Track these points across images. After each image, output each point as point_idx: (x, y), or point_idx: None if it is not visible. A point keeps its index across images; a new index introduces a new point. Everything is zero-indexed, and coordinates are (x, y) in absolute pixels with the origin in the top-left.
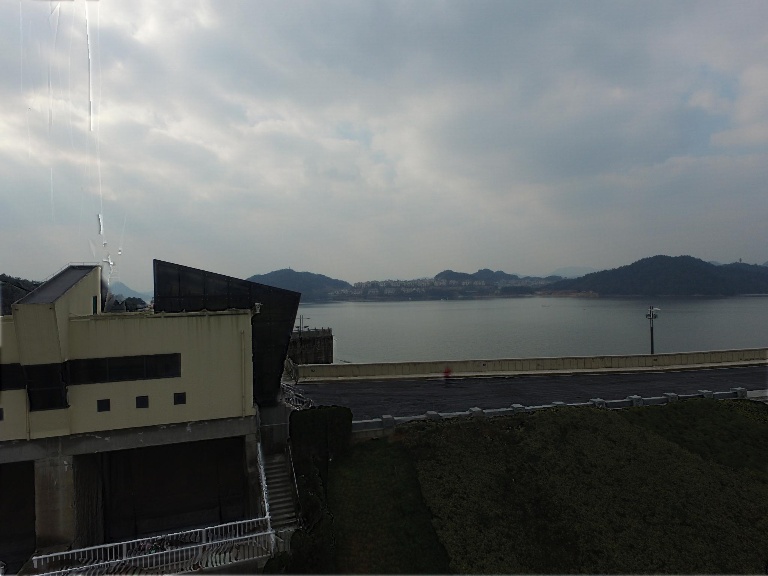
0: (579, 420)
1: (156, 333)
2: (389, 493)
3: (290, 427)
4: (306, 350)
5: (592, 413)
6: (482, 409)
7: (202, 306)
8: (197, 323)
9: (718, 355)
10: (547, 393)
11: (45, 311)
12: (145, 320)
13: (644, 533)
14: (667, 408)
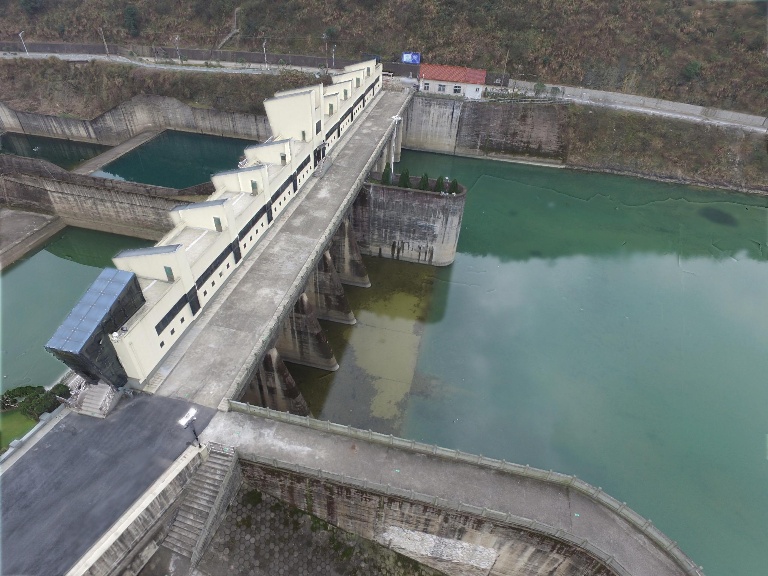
0: None
1: None
2: None
3: None
4: None
5: None
6: None
7: None
8: None
9: None
10: None
11: None
12: None
13: None
14: None
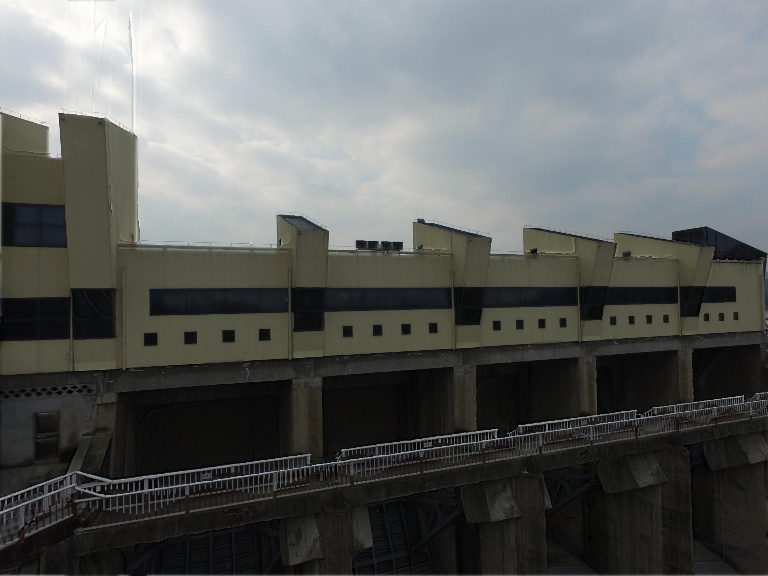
0: None
1: (725, 273)
2: None
3: None
4: None
5: None
6: None
7: (723, 259)
8: (741, 267)
9: None
10: None
11: (711, 252)
12: (721, 264)
13: None
14: None
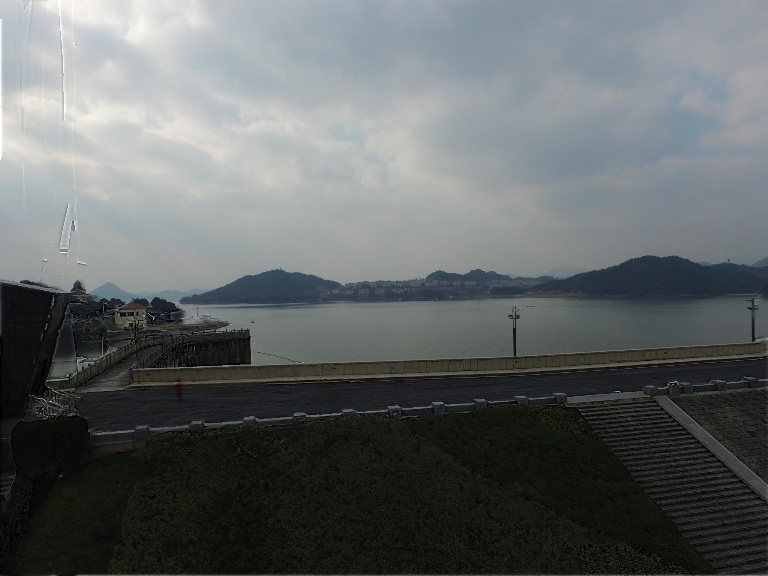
0: (354, 430)
1: None
2: (96, 514)
3: (11, 440)
4: (219, 352)
5: (373, 422)
6: (271, 417)
7: None
8: None
9: (587, 357)
10: (366, 399)
11: None
12: None
13: (351, 560)
14: (465, 416)
